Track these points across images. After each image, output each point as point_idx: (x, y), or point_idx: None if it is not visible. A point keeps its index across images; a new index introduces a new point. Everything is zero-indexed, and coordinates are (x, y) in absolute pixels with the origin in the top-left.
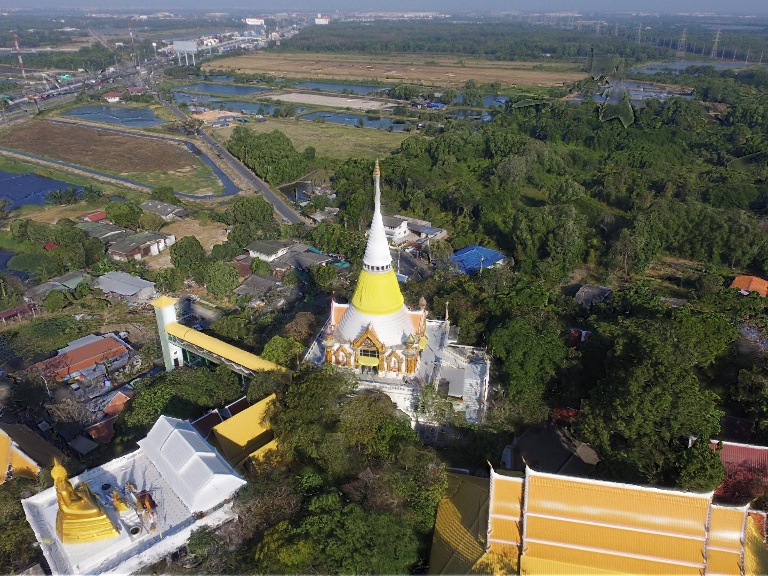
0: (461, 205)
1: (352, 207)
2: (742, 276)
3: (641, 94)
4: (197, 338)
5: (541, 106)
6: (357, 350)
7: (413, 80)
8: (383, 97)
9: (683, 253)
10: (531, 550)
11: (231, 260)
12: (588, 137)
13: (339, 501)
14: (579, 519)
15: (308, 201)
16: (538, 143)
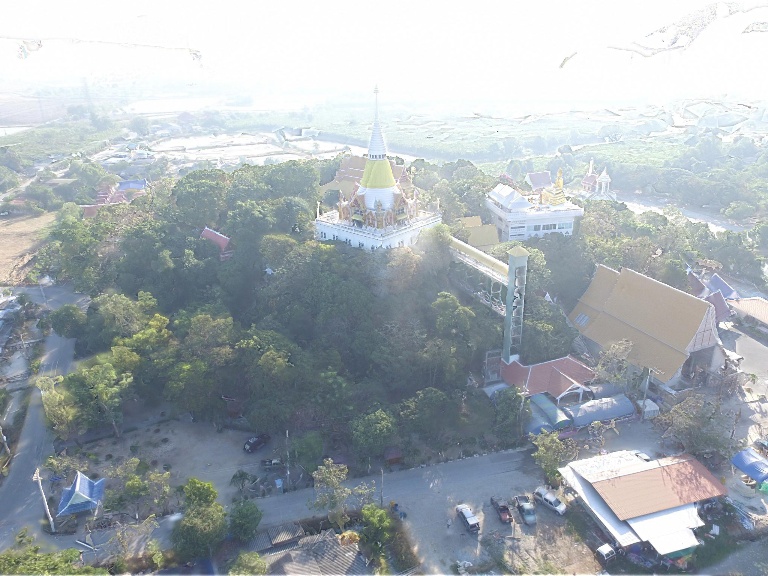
0: None
1: None
2: None
3: None
4: None
5: None
6: None
7: None
8: None
9: None
10: None
11: None
12: None
13: None
14: None
15: None
16: None
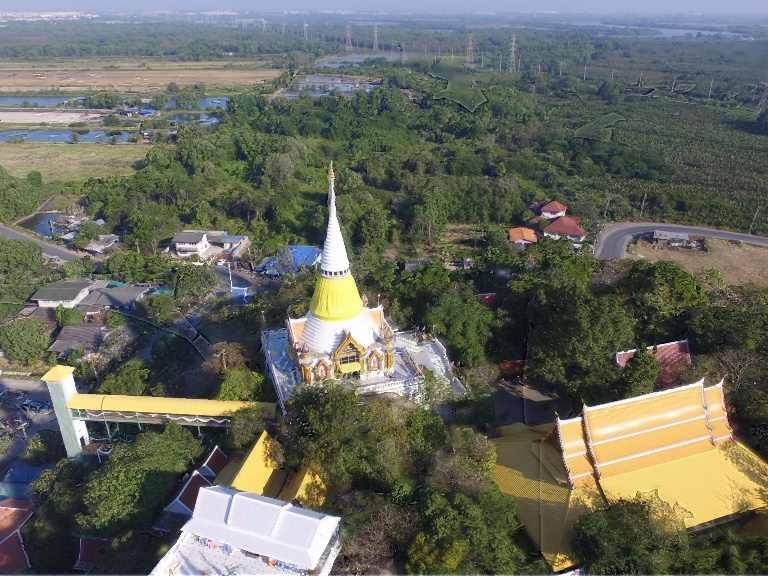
0: (254, 209)
1: (140, 229)
2: (513, 229)
3: (340, 86)
4: (122, 403)
5: (261, 104)
6: (338, 360)
7: (104, 87)
8: (78, 108)
9: (460, 219)
10: (604, 473)
11: (15, 317)
12: (323, 129)
13: (441, 497)
14: (628, 434)
15: (71, 232)
16: (288, 139)
